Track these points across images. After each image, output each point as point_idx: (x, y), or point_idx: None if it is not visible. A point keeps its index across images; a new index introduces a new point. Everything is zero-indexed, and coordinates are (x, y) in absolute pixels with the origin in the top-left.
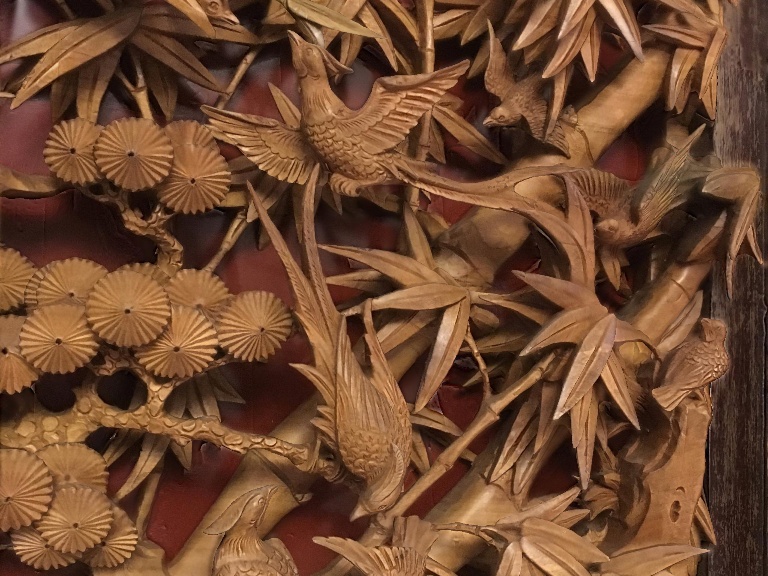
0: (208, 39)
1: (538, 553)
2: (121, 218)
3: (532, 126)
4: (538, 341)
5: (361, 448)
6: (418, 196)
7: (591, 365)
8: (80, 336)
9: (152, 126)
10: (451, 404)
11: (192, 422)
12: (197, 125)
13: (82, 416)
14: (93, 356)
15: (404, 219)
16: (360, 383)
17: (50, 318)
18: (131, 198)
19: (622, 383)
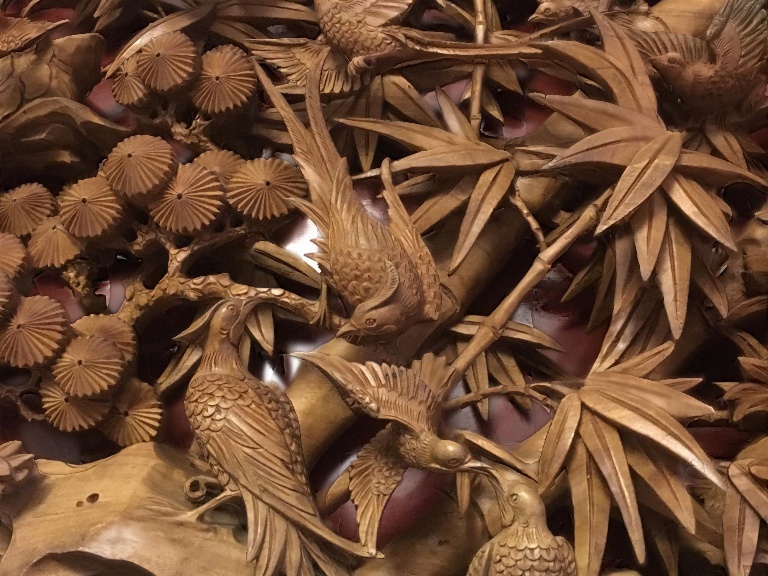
0: (275, 20)
1: (600, 399)
2: (171, 132)
3: (586, 15)
4: (565, 154)
5: (351, 267)
6: (479, 110)
7: (644, 176)
8: (104, 198)
9: (179, 35)
10: (551, 325)
11: (202, 276)
12: (232, 48)
13: (128, 304)
14: (118, 220)
15: (438, 102)
16: (355, 211)
17: (82, 186)
18: (182, 118)
19: (706, 206)
